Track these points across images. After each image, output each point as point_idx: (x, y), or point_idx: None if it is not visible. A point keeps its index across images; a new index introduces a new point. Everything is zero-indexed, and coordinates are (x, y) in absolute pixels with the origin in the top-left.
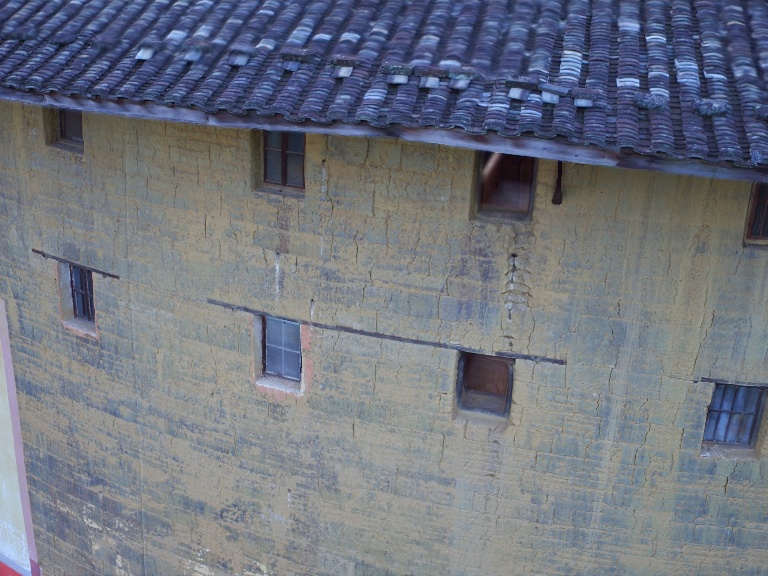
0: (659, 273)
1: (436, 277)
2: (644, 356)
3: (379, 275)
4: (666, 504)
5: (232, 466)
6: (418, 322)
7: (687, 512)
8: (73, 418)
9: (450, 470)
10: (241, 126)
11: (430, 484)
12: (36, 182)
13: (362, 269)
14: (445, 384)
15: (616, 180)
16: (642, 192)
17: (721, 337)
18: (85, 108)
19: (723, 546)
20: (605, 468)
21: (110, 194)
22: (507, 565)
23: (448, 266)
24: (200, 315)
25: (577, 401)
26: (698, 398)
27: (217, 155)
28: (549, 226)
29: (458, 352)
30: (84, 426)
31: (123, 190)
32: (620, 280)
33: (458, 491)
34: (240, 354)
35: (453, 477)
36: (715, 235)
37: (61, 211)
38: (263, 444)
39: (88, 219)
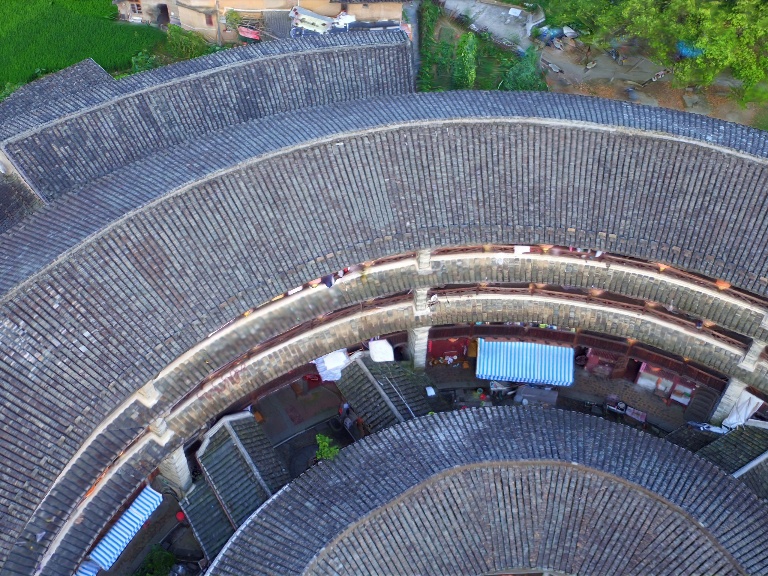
0: None
1: None
2: None
3: None
4: None
5: None
6: None
7: None
8: None
9: None
10: None
11: None
12: None
13: None
14: None
15: None
16: None
17: None
18: None
19: None
20: None
21: None
22: None
23: None
24: None
25: None
26: None
27: None
28: None
29: None
30: None
31: None
32: None
33: None
34: None
35: None
36: None
37: None
38: None
39: None
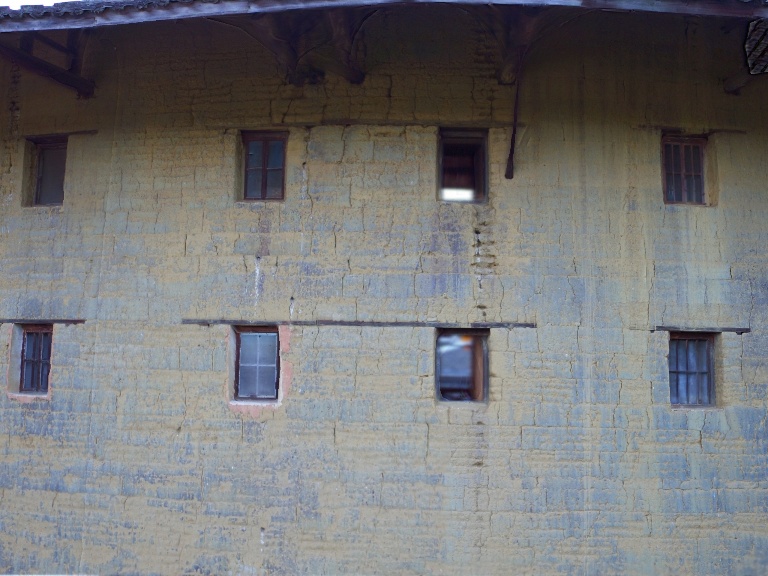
0: (603, 231)
1: (410, 256)
2: (604, 310)
3: (357, 262)
4: (651, 469)
5: (196, 515)
6: (396, 303)
7: (672, 476)
8: (1, 513)
9: (437, 465)
10: (279, 8)
11: (417, 486)
12: (3, 246)
13: (341, 258)
14: (426, 365)
15: (555, 154)
16: (577, 163)
17: (665, 285)
18: (135, 19)
19: (713, 513)
20: (588, 435)
21: (86, 236)
22: (506, 575)
23: (421, 244)
24: (172, 339)
25: (552, 364)
26: (658, 348)
27: (202, 176)
28: (505, 198)
29: (436, 330)
30: (14, 519)
31: (101, 229)
32: (572, 240)
33: (447, 489)
34: (214, 373)
35: (441, 473)
36: (641, 194)
37: (27, 268)
38: (234, 476)
39: (57, 268)
